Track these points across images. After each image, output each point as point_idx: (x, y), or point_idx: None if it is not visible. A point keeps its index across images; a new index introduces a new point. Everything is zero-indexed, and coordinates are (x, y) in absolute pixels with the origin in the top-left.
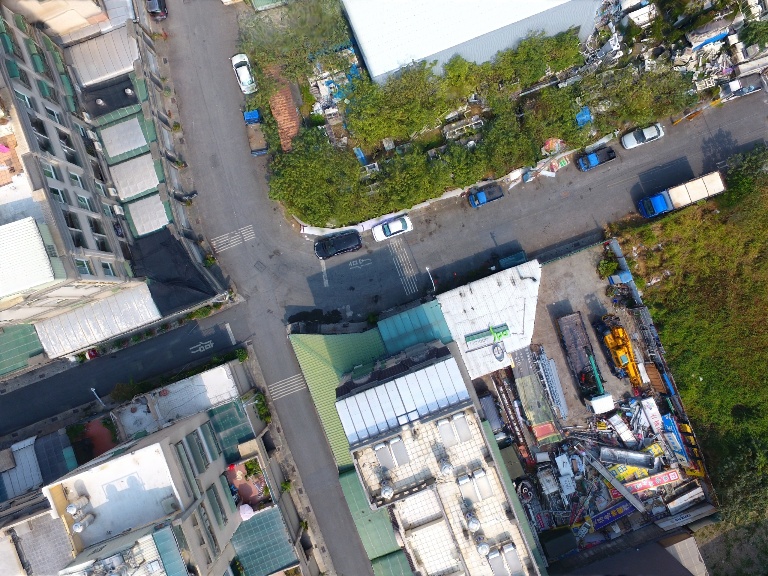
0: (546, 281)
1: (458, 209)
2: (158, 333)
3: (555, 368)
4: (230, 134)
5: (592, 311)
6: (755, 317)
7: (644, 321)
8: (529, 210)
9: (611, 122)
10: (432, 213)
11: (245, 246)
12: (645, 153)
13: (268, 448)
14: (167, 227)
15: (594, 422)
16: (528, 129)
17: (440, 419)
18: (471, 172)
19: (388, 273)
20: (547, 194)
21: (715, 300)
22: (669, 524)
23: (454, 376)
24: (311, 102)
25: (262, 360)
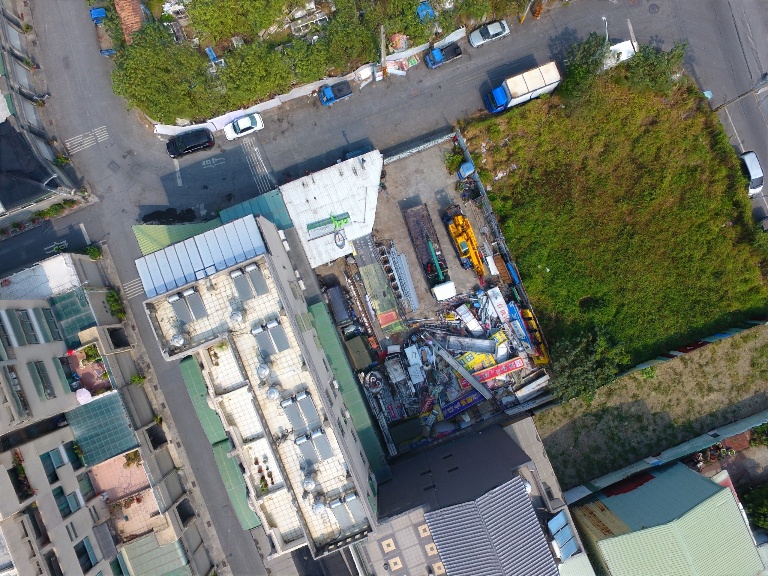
0: (397, 178)
1: (310, 108)
2: (12, 234)
3: (406, 262)
4: (83, 36)
5: (442, 206)
6: (599, 208)
7: (486, 210)
8: (380, 108)
9: (453, 17)
10: (285, 112)
11: (99, 147)
12: (493, 51)
13: (122, 345)
14: (7, 119)
15: (443, 313)
16: (367, 21)
17: (233, 270)
18: (311, 64)
19: (241, 172)
20: (398, 92)
21: (561, 192)
22: (515, 410)
23: (252, 232)
24: (162, 3)
25: (117, 259)
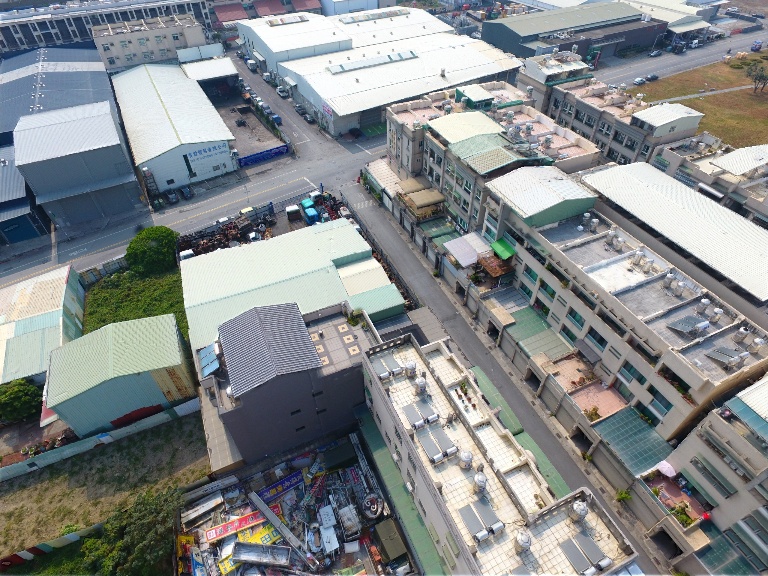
0: None
1: None
2: None
3: None
4: None
5: None
6: None
7: None
8: None
9: None
10: None
11: None
12: None
13: (659, 537)
14: None
15: None
16: None
17: None
18: None
19: None
20: None
21: None
22: (227, 481)
23: None
24: None
25: None
